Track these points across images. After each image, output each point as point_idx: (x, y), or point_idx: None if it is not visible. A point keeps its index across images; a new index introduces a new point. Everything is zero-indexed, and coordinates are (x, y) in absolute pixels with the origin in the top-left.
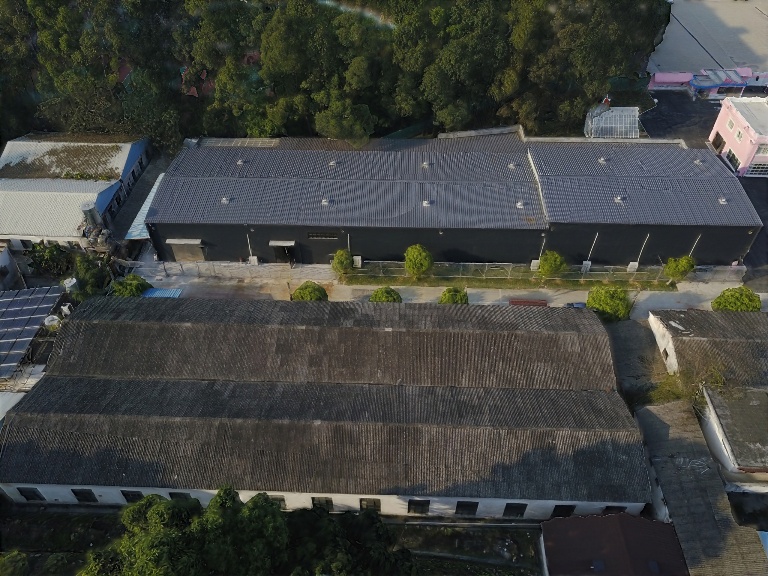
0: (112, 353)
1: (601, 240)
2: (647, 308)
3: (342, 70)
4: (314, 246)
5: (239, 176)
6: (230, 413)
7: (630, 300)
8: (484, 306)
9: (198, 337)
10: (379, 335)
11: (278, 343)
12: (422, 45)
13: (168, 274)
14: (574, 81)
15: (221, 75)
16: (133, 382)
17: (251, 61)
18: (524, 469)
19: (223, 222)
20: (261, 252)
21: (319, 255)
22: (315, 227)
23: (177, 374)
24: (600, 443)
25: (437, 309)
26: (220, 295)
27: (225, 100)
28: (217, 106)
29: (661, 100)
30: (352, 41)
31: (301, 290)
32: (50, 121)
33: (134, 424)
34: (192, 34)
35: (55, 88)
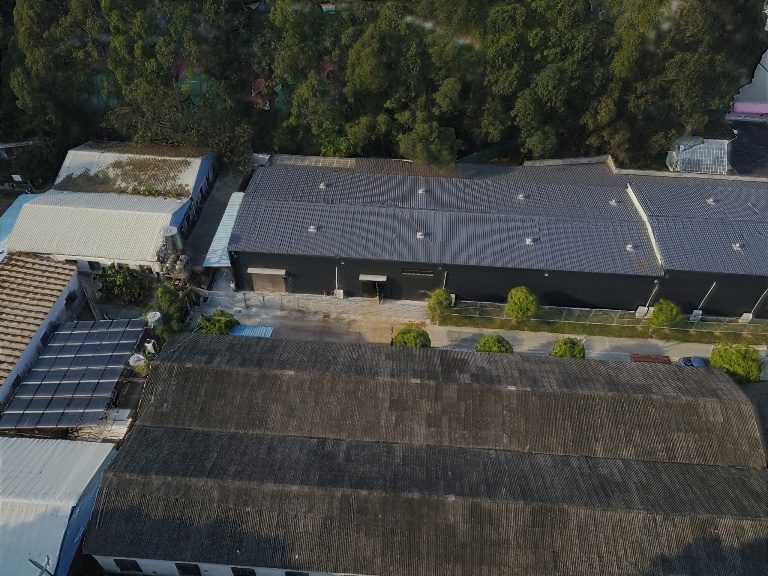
0: (209, 402)
1: (717, 289)
2: (766, 365)
3: (432, 91)
4: (406, 282)
5: (324, 202)
6: (351, 482)
7: (761, 360)
8: (606, 362)
9: (303, 388)
10: (502, 394)
11: (392, 398)
12: (518, 68)
13: (247, 305)
14: (669, 112)
15: (302, 90)
16: (235, 438)
17: (331, 76)
18: (686, 562)
19: (313, 253)
20: (348, 285)
21: (410, 291)
22: (412, 263)
23: (282, 430)
24: (767, 534)
25: (556, 364)
26: (306, 332)
27: (302, 116)
28: (293, 122)
29: (740, 131)
30: (446, 61)
31: (404, 334)
32: (111, 129)
33: (246, 492)
34: (274, 45)
35: (121, 95)
